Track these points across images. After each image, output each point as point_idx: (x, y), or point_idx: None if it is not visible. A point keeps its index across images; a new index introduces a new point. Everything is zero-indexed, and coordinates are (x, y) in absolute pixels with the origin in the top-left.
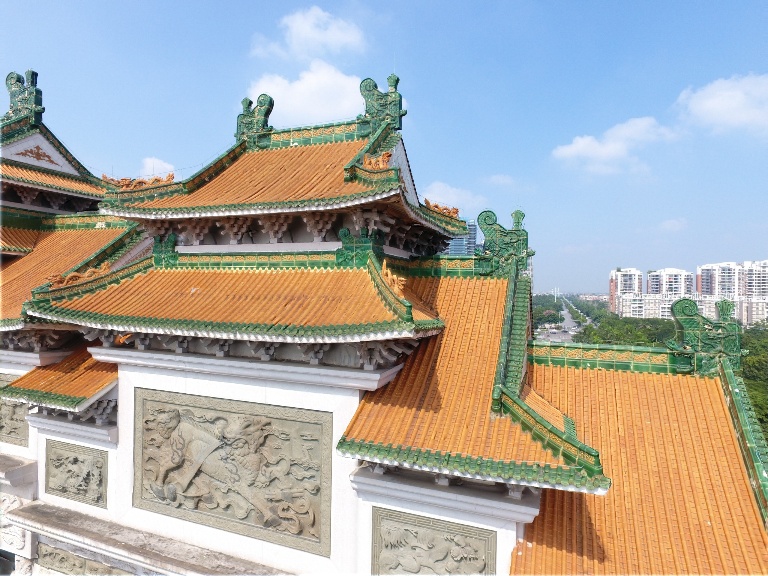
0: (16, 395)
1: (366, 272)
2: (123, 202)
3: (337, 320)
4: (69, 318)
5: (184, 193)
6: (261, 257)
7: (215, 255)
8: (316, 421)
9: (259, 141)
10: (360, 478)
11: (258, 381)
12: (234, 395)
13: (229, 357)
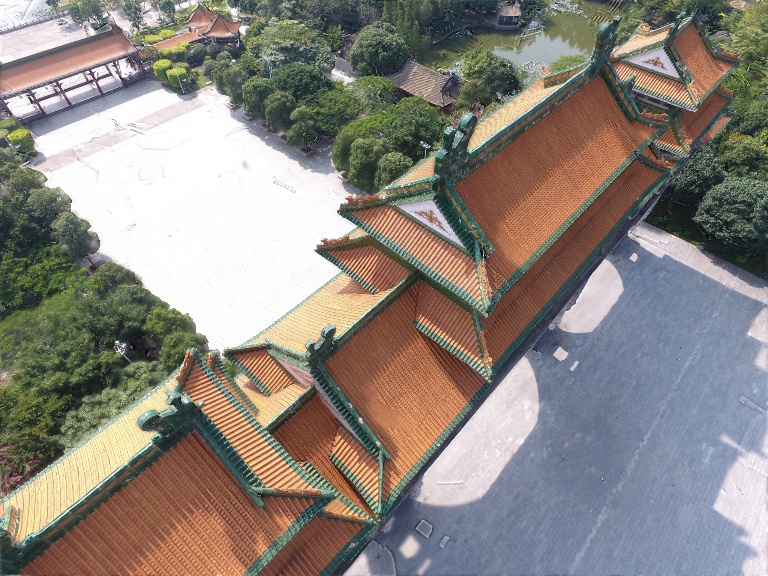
0: None
1: None
2: None
3: None
4: None
5: None
6: None
7: None
8: None
9: None
10: None
11: None
12: None
13: None
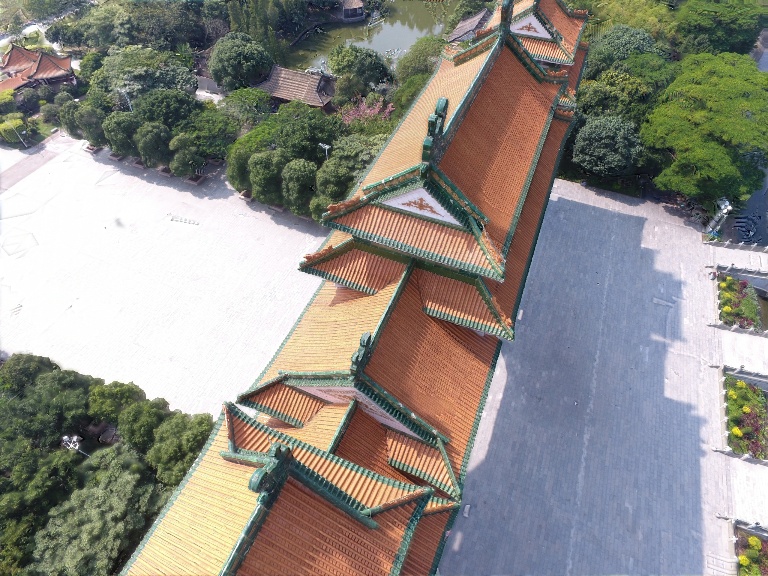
0: None
1: None
2: None
3: None
4: None
5: None
6: None
7: None
8: None
9: None
10: None
11: None
12: None
13: None
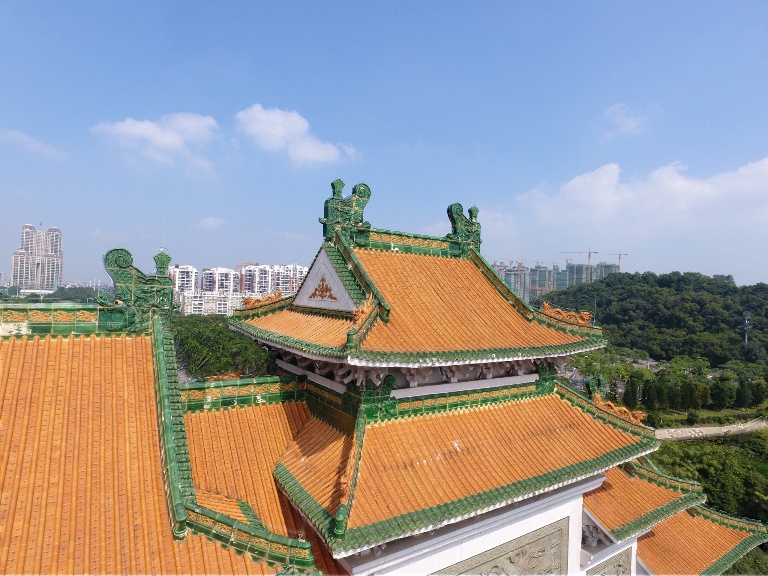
0: None
1: (559, 398)
2: None
3: (603, 447)
4: (395, 535)
5: (385, 321)
6: (483, 394)
7: (441, 397)
8: (559, 528)
9: (356, 236)
10: (596, 555)
11: (525, 515)
12: (506, 538)
13: None
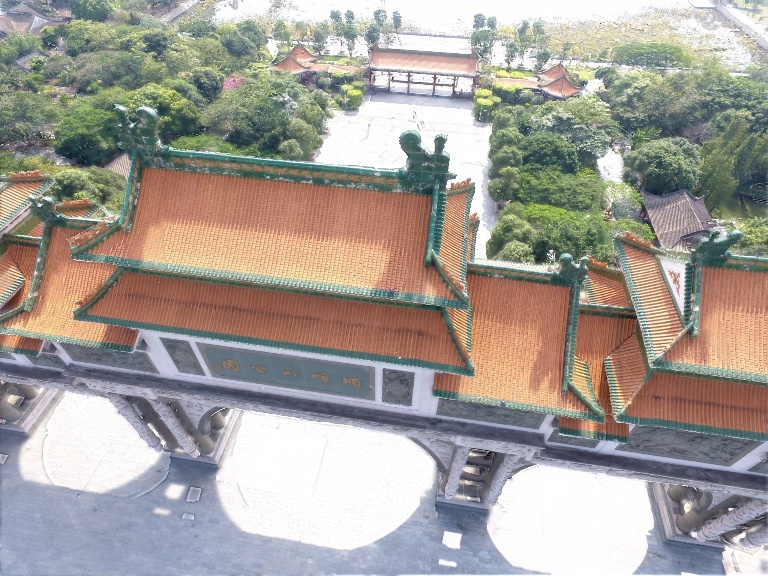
0: None
1: None
2: (43, 180)
3: None
4: None
5: None
6: None
7: None
8: None
9: None
10: None
11: None
12: None
13: None
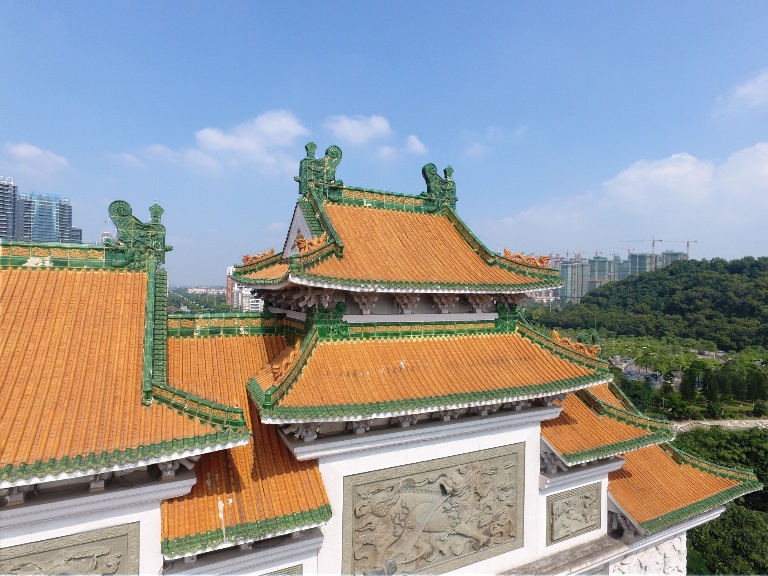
0: (212, 542)
1: (519, 336)
2: (304, 268)
3: (553, 376)
4: (323, 416)
5: (339, 257)
6: (438, 326)
7: (393, 325)
8: (514, 452)
9: (329, 193)
10: (553, 479)
11: (474, 433)
12: (454, 451)
13: (454, 419)
